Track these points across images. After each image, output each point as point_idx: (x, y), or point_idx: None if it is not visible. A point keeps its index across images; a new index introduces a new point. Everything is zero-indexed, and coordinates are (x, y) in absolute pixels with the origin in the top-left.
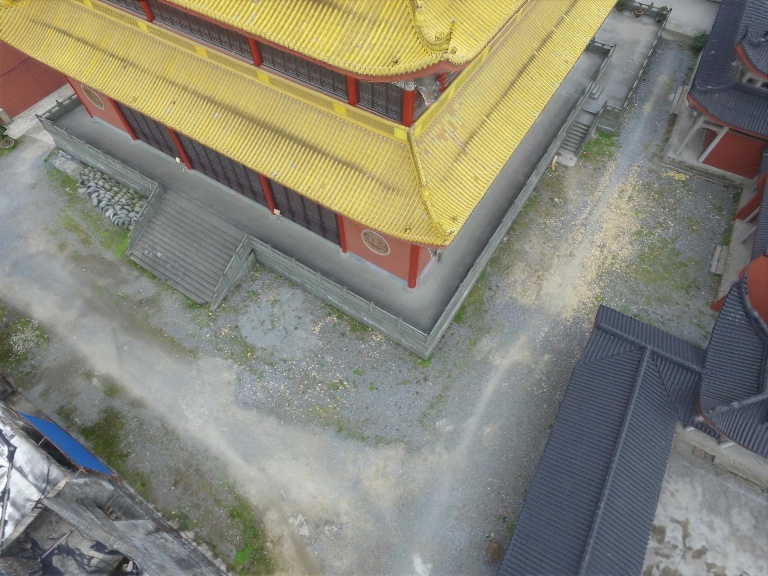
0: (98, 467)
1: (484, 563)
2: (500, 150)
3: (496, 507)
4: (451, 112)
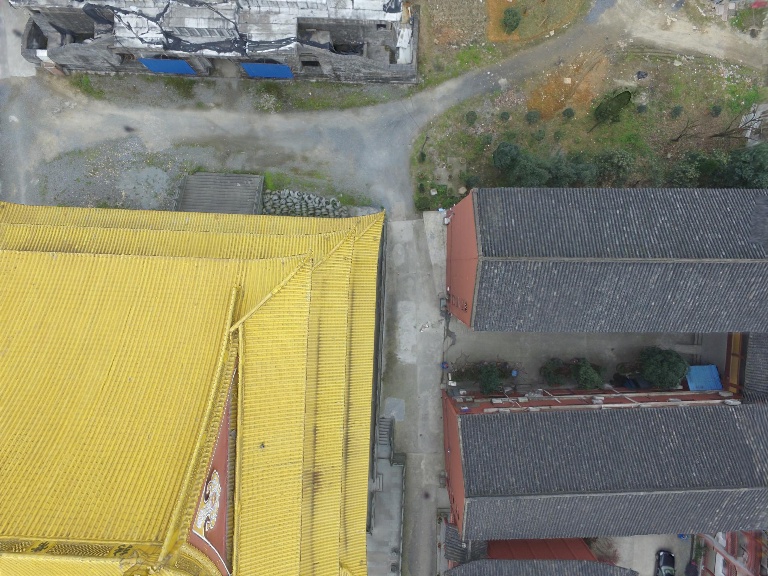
0: None
1: None
2: None
3: None
4: None
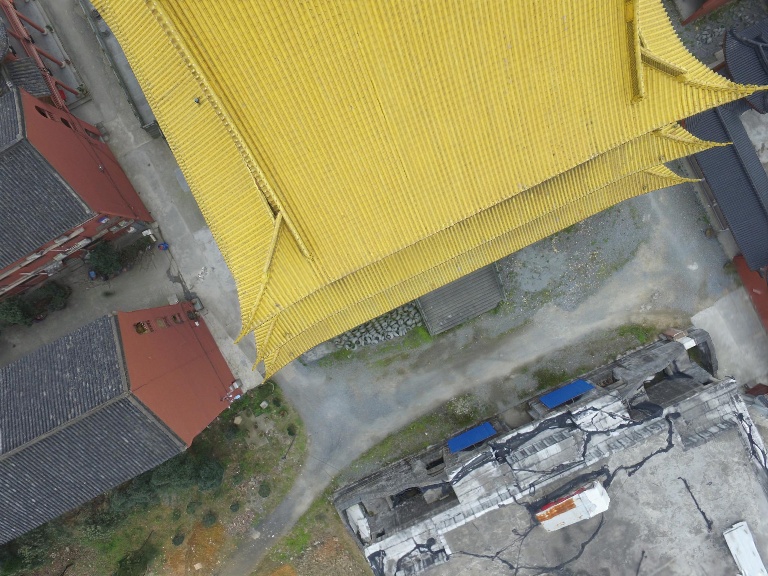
0: (582, 383)
1: (709, 240)
2: None
3: (693, 220)
4: None
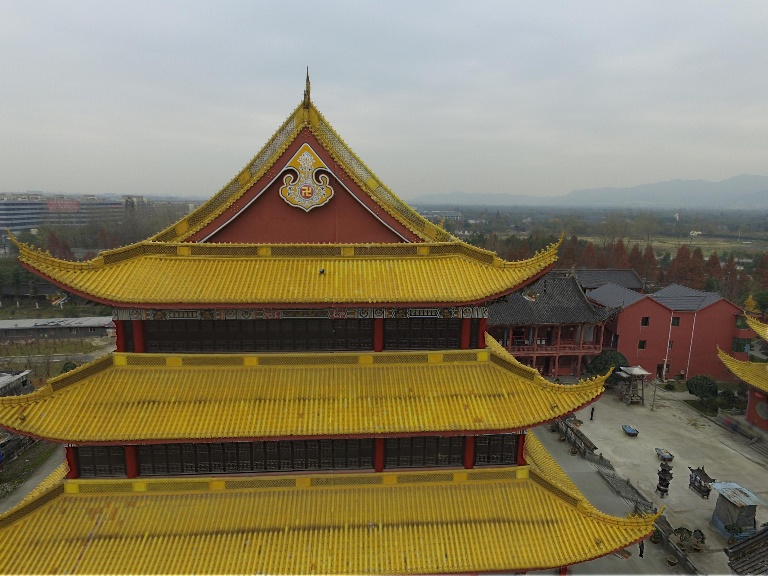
0: None
1: None
2: (110, 572)
3: None
4: (129, 504)
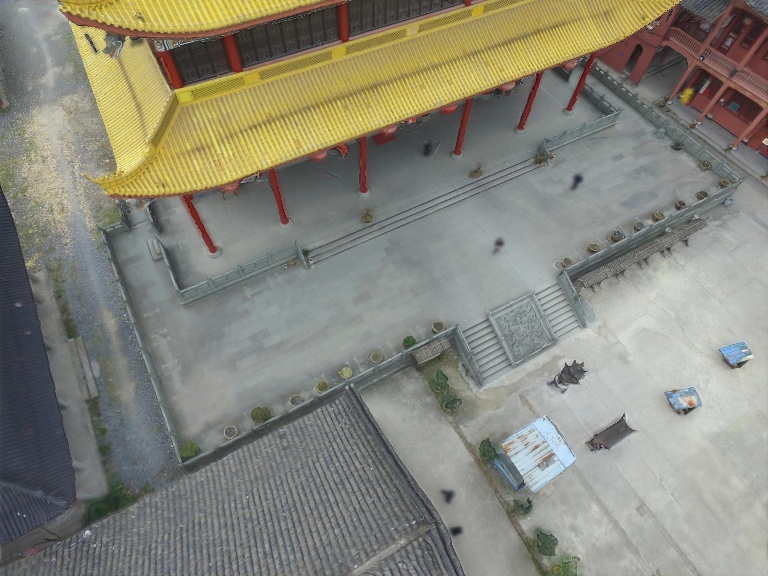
0: None
1: None
2: None
3: (7, 37)
4: None
